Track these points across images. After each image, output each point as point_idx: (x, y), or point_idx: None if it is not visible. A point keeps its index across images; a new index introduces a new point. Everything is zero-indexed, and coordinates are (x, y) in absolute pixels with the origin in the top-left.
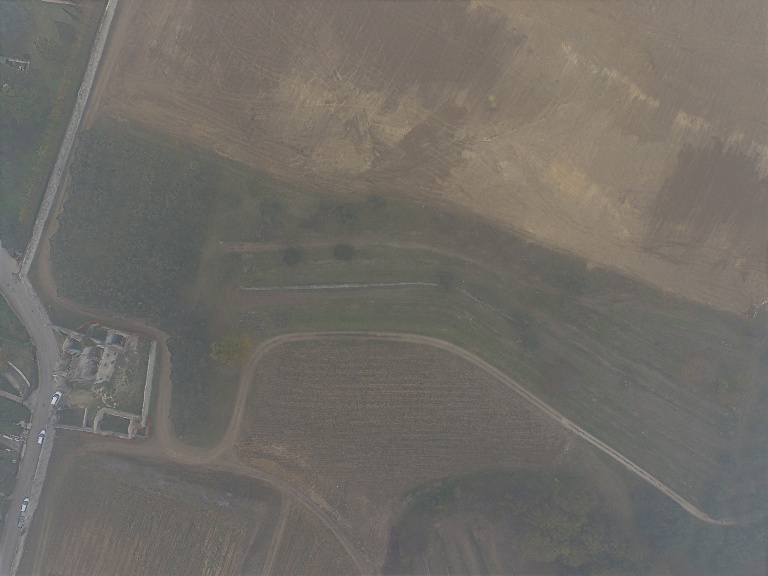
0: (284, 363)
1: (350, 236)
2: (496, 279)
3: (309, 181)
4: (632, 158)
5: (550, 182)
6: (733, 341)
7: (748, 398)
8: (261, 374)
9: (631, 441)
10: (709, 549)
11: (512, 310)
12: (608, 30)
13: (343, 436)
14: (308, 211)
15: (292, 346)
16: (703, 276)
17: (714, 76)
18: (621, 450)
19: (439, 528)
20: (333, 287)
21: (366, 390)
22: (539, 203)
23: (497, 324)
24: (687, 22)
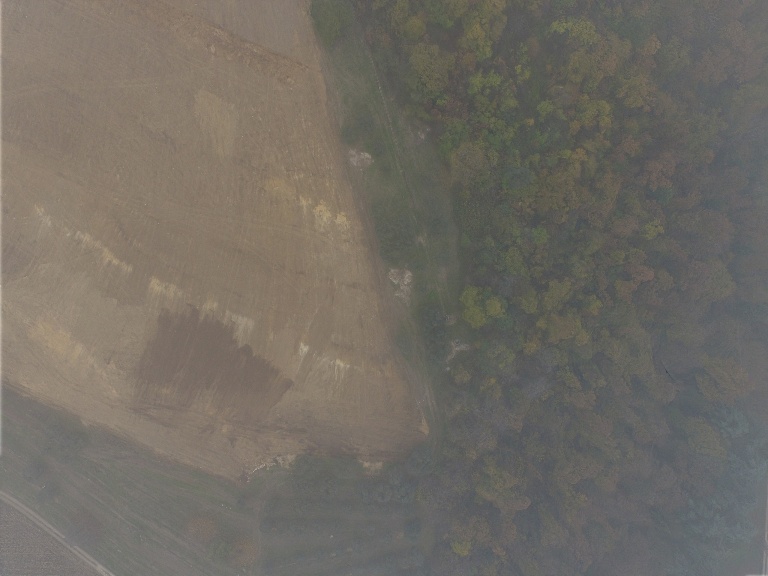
0: None
1: None
2: (12, 426)
3: None
4: (114, 320)
5: (38, 339)
6: (233, 504)
7: (258, 560)
8: None
9: None
10: None
11: (33, 457)
12: (77, 195)
13: None
14: None
15: None
16: (193, 440)
17: (181, 245)
18: None
19: None
20: None
21: None
22: (31, 359)
23: None
24: (151, 191)
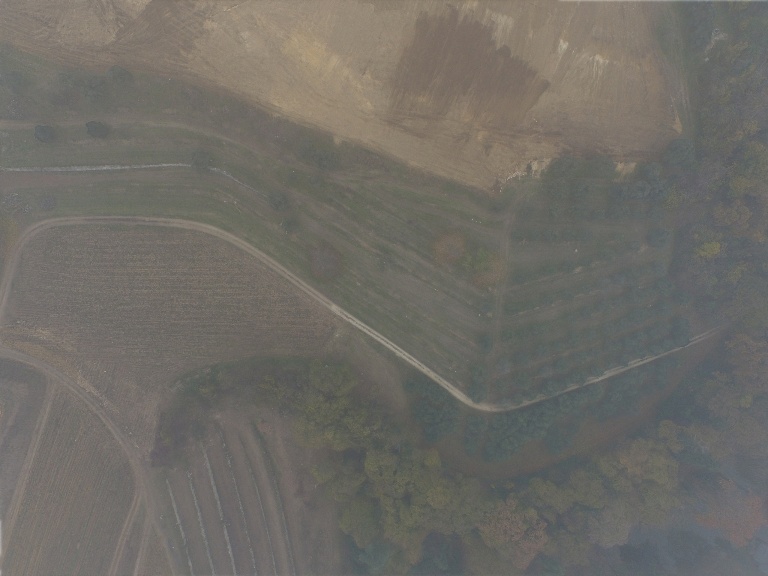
0: (51, 247)
1: (107, 114)
2: (254, 159)
3: (55, 53)
4: (370, 27)
5: (292, 53)
6: (483, 218)
7: (503, 278)
8: (27, 258)
9: (397, 326)
10: (477, 435)
11: (273, 191)
12: None
13: (111, 321)
14: (57, 86)
15: (59, 230)
16: (447, 150)
17: None
18: (388, 336)
19: (220, 420)
20: (96, 169)
21: (134, 275)
22: (283, 75)
23: (260, 207)
24: None
